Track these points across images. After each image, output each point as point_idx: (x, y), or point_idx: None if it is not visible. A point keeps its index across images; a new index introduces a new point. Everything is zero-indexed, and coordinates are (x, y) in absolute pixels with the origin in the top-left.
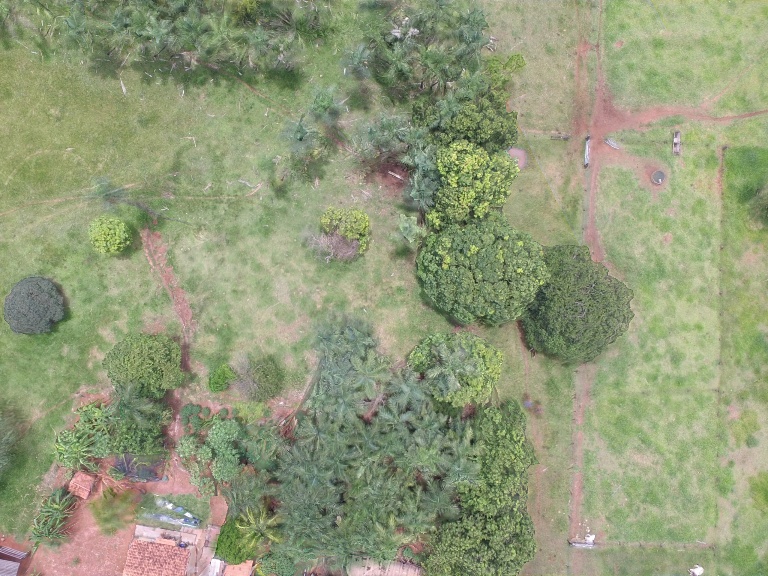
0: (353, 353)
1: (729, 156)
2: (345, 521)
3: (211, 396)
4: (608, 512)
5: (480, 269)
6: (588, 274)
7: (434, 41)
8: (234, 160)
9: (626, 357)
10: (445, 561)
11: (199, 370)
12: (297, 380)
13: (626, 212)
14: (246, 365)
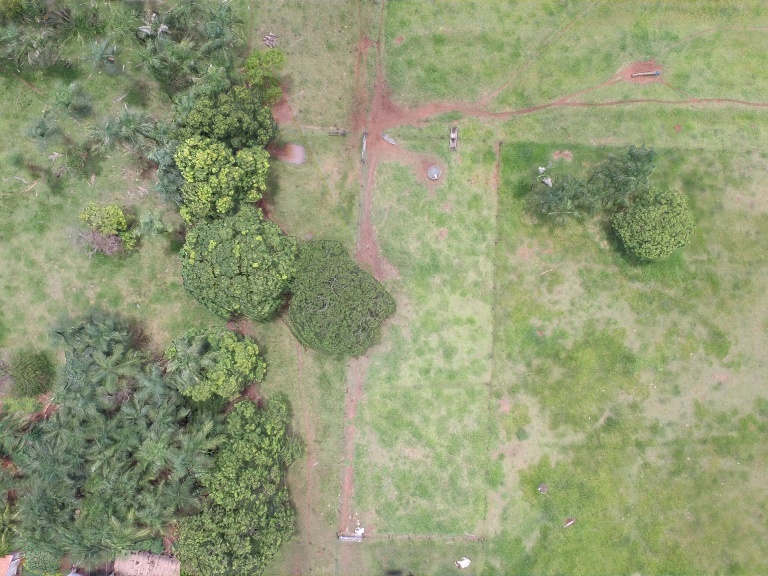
0: (96, 348)
1: (506, 151)
2: (81, 515)
3: None
4: (378, 505)
5: (218, 264)
6: (330, 268)
7: (187, 37)
8: (11, 157)
9: (398, 351)
10: None
11: None
12: None
13: (403, 207)
14: (17, 361)
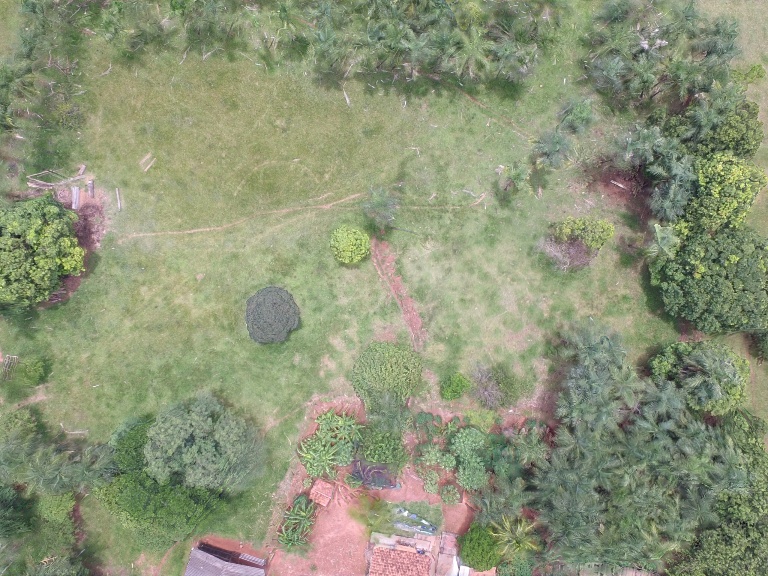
0: (610, 362)
1: None
2: (610, 529)
3: (441, 404)
4: None
5: (740, 279)
6: None
7: (678, 52)
8: (457, 170)
9: None
10: (698, 568)
11: (429, 378)
12: (526, 388)
13: None
14: (476, 373)
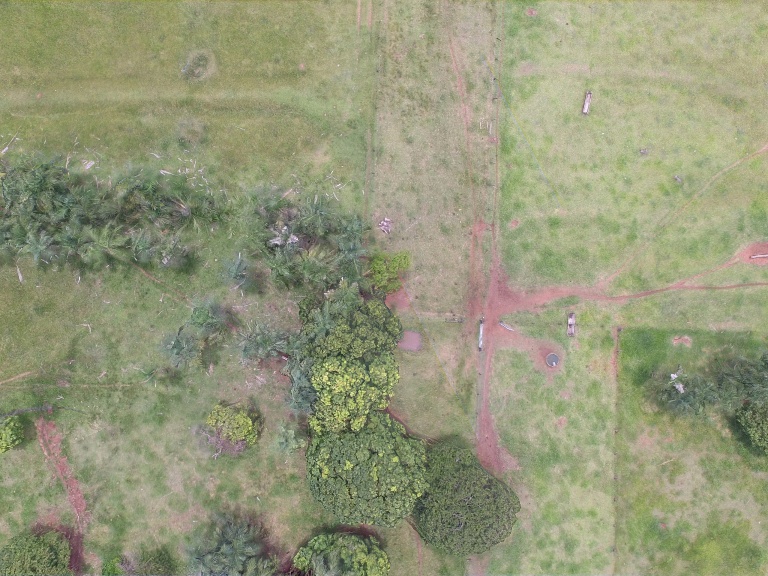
0: (231, 567)
1: (624, 337)
2: None
3: None
4: None
5: (355, 485)
6: (466, 486)
7: (315, 245)
8: (129, 347)
9: (520, 544)
10: None
11: (93, 561)
12: (190, 570)
13: (521, 395)
14: (139, 556)
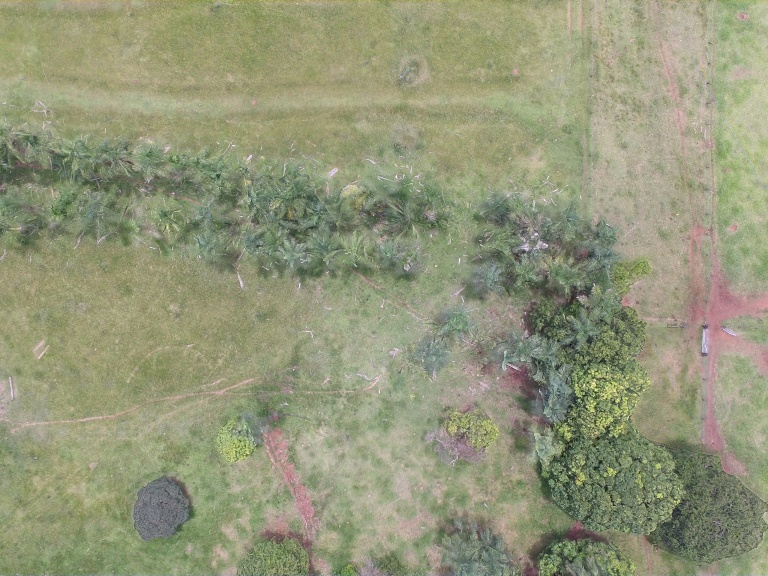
0: (490, 574)
1: None
2: None
3: None
4: None
5: (618, 492)
6: (725, 493)
7: (561, 251)
8: (352, 353)
9: None
10: None
11: (322, 567)
12: None
13: (745, 400)
14: (369, 563)
